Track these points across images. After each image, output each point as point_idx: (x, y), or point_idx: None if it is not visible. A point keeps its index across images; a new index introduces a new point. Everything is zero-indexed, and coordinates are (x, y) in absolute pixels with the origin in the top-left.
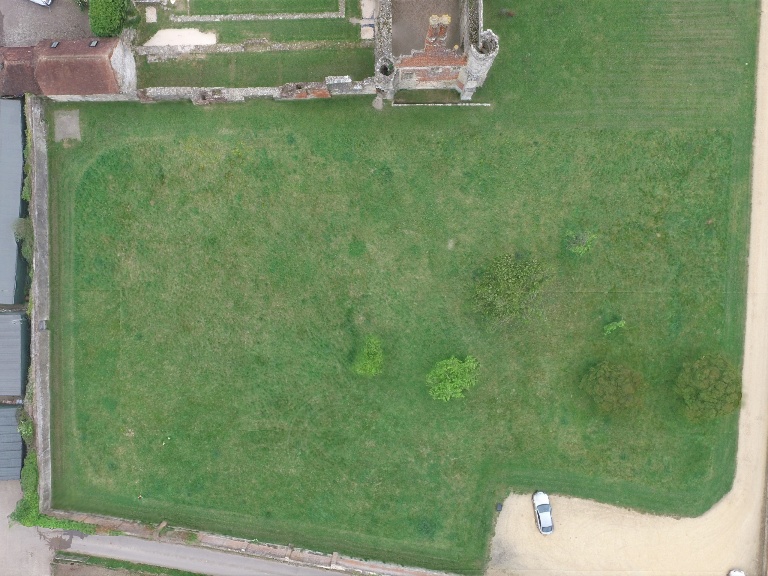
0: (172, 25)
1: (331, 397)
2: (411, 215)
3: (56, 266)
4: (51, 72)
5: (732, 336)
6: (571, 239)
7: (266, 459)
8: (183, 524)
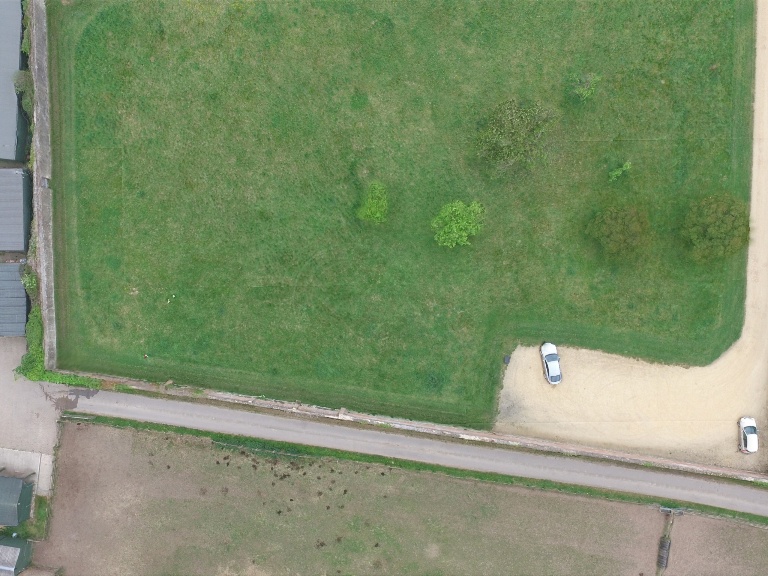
0: None
1: (336, 252)
2: (413, 66)
3: (57, 125)
4: None
5: (738, 182)
6: (575, 83)
7: (272, 315)
8: (189, 383)
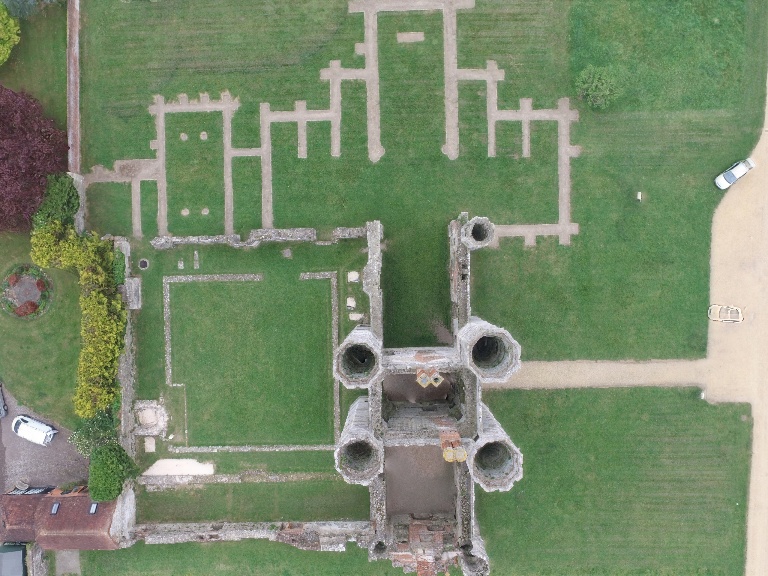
0: (170, 455)
1: None
2: None
3: None
4: (52, 540)
5: None
6: None
7: None
8: None
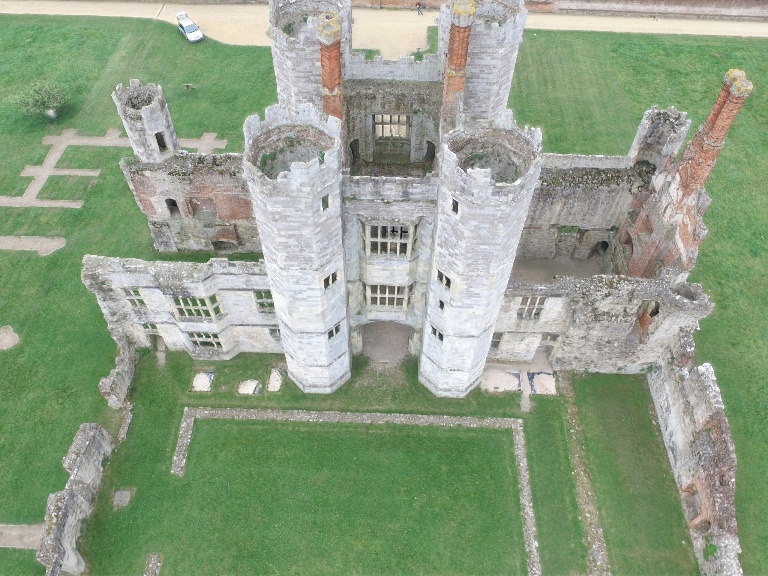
0: None
1: None
2: None
3: None
4: None
5: None
6: None
7: None
8: None
